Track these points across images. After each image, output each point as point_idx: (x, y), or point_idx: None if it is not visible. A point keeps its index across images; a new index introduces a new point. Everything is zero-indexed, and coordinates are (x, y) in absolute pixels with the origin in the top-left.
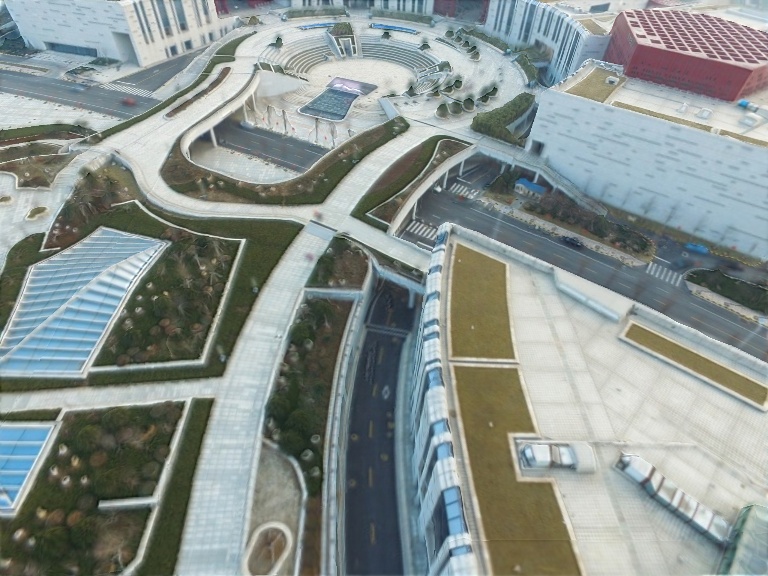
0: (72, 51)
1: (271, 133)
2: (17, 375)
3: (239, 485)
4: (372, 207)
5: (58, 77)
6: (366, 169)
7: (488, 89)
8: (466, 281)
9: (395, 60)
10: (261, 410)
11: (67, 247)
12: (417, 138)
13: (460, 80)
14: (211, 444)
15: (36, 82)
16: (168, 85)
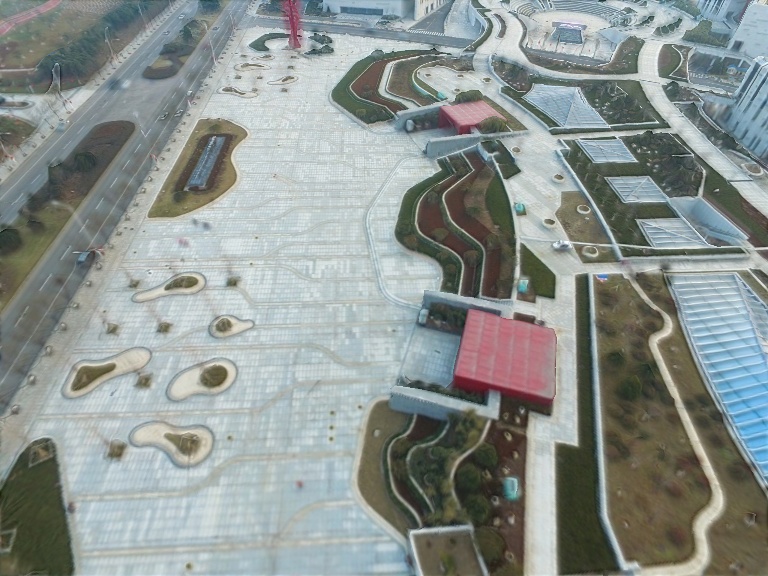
0: (362, 12)
1: (546, 51)
2: (579, 128)
3: None
4: (670, 73)
5: (372, 27)
6: (646, 58)
7: (670, 22)
8: None
9: (581, 11)
10: (703, 136)
11: (529, 91)
12: (656, 45)
13: (647, 18)
14: None
15: (363, 30)
16: (448, 29)
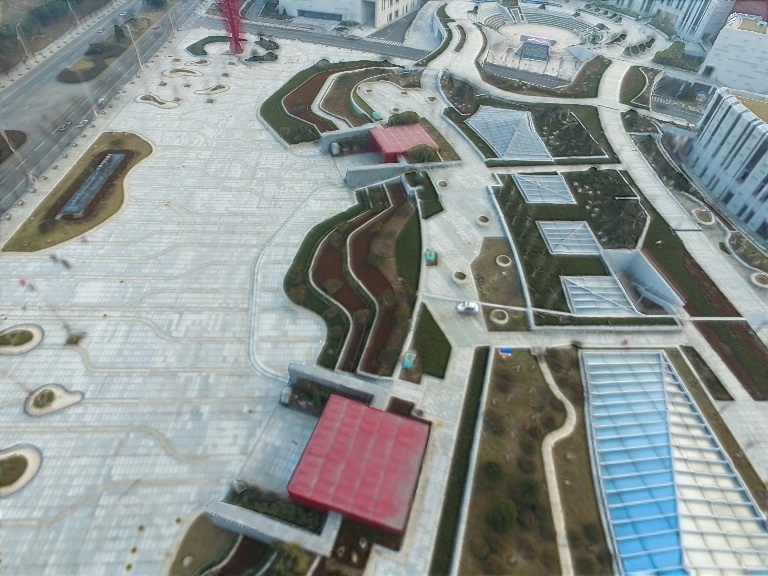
0: (320, 17)
1: (508, 68)
2: (519, 160)
3: (668, 199)
4: (631, 99)
5: (327, 33)
6: (609, 81)
7: (643, 41)
8: (755, 108)
9: (554, 25)
10: (655, 175)
11: (474, 113)
12: (623, 67)
13: None
14: (641, 186)
15: (317, 36)
16: (408, 39)
